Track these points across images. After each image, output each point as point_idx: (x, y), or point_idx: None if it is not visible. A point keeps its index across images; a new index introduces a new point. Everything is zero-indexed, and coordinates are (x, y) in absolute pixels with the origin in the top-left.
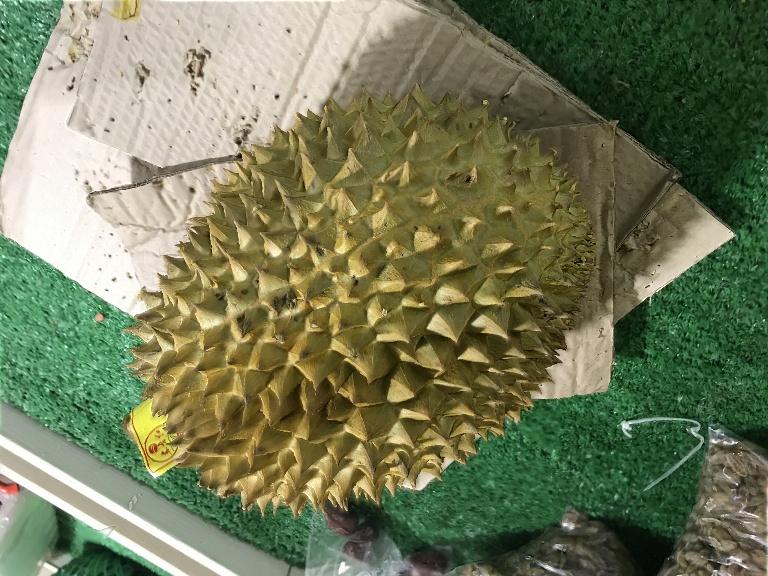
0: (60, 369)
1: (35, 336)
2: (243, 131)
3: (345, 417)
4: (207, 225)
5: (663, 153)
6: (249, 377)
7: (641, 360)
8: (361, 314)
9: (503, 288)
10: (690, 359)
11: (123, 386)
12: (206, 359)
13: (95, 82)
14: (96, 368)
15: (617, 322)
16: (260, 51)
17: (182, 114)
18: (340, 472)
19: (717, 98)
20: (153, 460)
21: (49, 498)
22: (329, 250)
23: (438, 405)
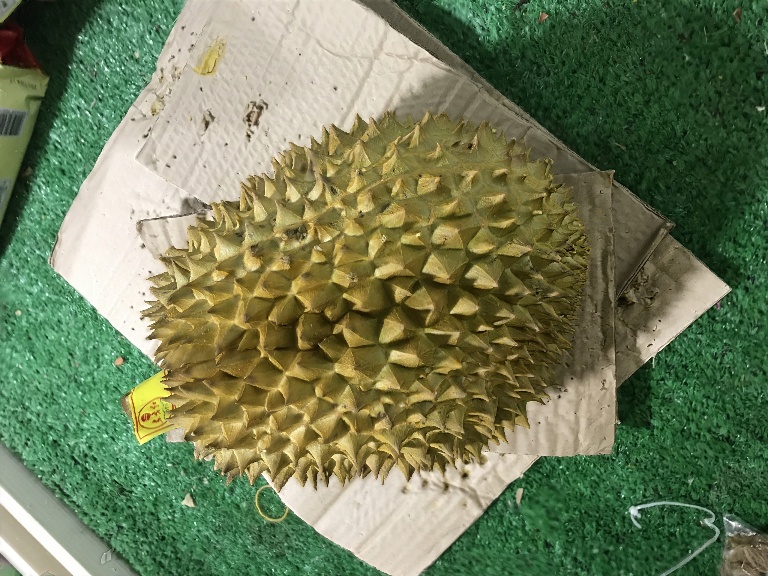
0: (68, 418)
1: (54, 380)
2: None
3: (336, 356)
4: None
5: (659, 211)
6: (252, 302)
7: (647, 432)
8: (363, 245)
9: (496, 243)
10: (698, 433)
11: (125, 441)
12: (216, 284)
13: (168, 123)
14: (103, 419)
15: (621, 386)
16: (309, 105)
17: (235, 157)
18: (324, 422)
19: (704, 161)
20: (143, 427)
21: (19, 567)
22: (342, 190)
23: (427, 351)
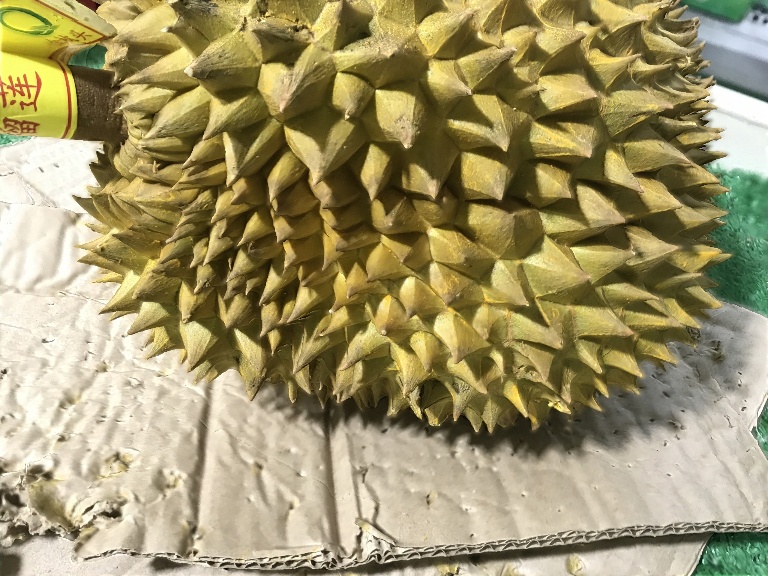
0: None
1: None
2: None
3: None
4: None
5: None
6: None
7: None
8: None
9: None
10: None
11: None
12: None
13: None
14: None
15: None
16: None
17: None
18: None
19: None
20: None
21: None
22: None
23: None
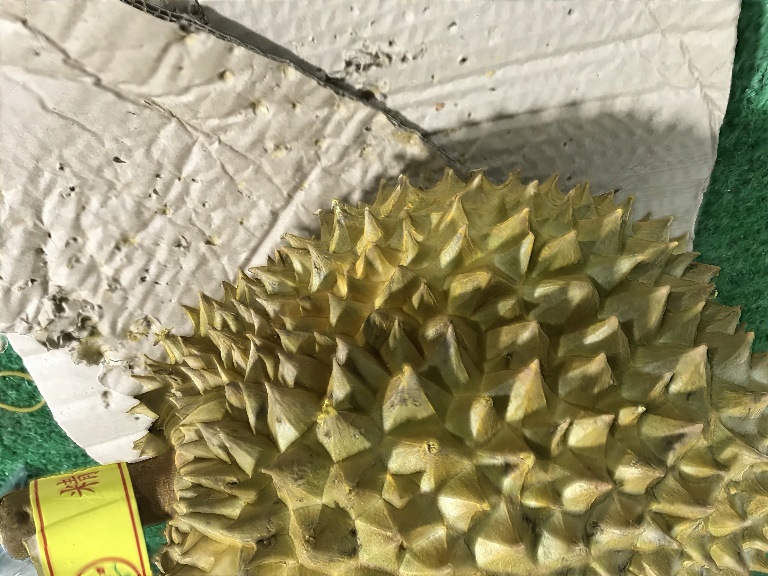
0: None
1: None
2: (373, 57)
3: None
4: (435, 303)
5: None
6: None
7: None
8: None
9: None
10: None
11: None
12: None
13: None
14: None
15: None
16: None
17: None
18: None
19: None
20: None
21: None
22: None
23: None
